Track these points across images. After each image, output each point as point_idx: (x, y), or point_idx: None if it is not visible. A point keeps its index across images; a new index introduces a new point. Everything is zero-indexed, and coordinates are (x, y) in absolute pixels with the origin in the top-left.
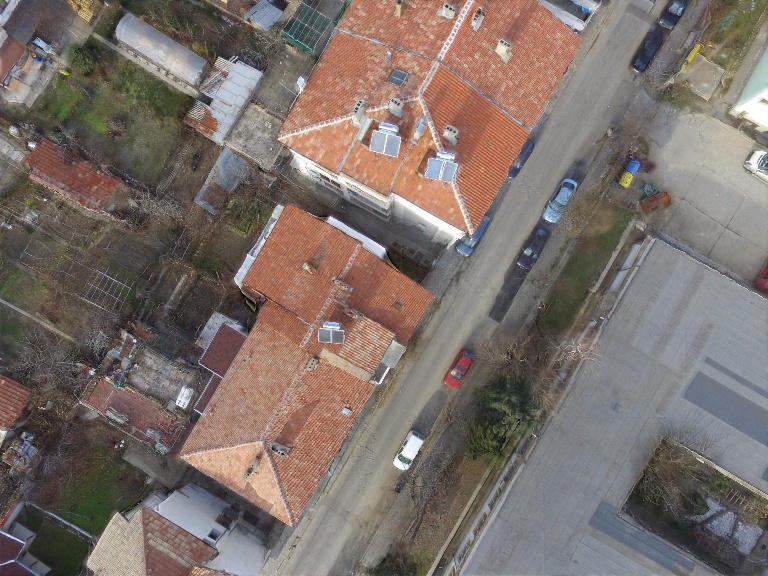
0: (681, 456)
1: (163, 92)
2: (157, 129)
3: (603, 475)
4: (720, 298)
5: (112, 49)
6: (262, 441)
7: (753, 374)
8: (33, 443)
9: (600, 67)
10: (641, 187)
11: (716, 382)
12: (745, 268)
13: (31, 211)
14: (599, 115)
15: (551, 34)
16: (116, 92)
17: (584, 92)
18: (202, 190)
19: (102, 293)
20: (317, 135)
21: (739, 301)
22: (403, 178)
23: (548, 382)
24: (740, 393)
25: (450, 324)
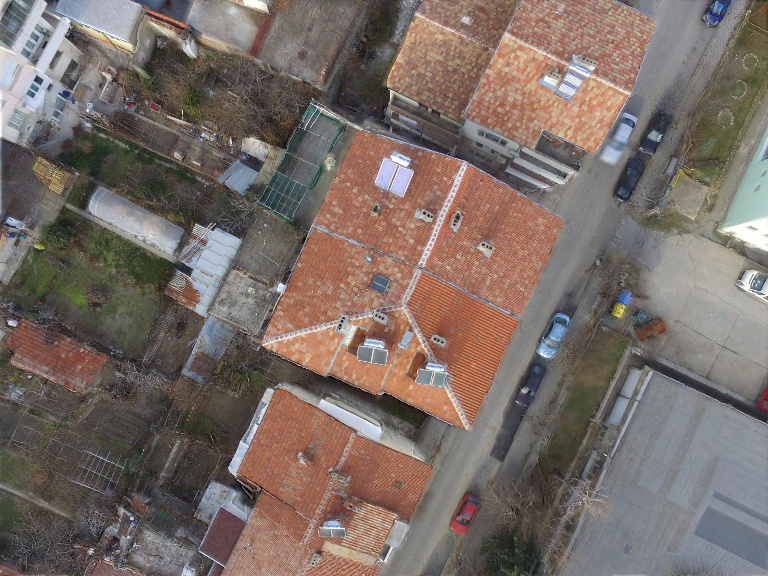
0: None
1: (142, 259)
2: (139, 298)
3: None
4: (723, 428)
5: (87, 219)
6: None
7: (762, 504)
8: None
9: (583, 195)
10: (634, 314)
11: (725, 516)
12: (745, 387)
13: (16, 390)
14: (586, 244)
15: (533, 220)
16: (94, 263)
17: (569, 221)
18: (189, 361)
19: (95, 475)
20: (302, 341)
21: (742, 430)
22: (393, 378)
23: (556, 526)
24: (751, 525)
25: (452, 466)
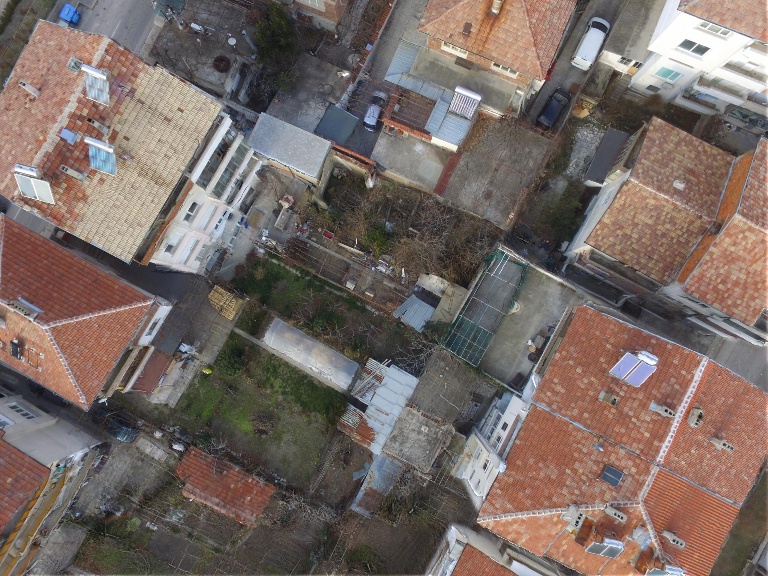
0: None
1: (309, 387)
2: (304, 426)
3: None
4: None
5: (254, 344)
6: None
7: None
8: None
9: None
10: None
11: None
12: None
13: (177, 512)
14: None
15: (761, 410)
16: (261, 389)
17: (736, 360)
18: (358, 497)
19: None
20: (521, 522)
21: None
22: (613, 564)
23: None
24: None
25: None
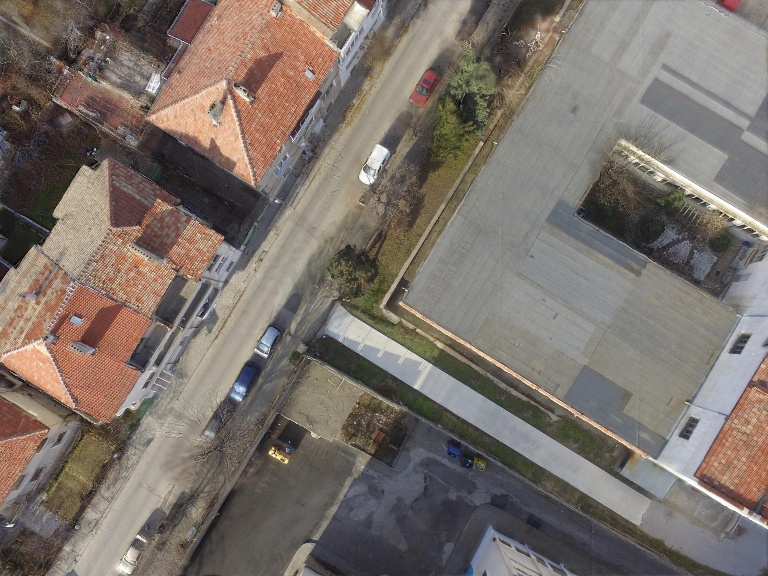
0: (640, 187)
1: None
2: None
3: (560, 175)
4: (677, 10)
5: None
6: (225, 80)
7: (707, 81)
8: (6, 139)
9: None
10: None
11: (671, 88)
12: None
13: None
14: None
15: None
16: None
17: None
18: None
19: None
20: None
21: (695, 13)
22: None
23: None
24: (694, 99)
25: (417, 47)
